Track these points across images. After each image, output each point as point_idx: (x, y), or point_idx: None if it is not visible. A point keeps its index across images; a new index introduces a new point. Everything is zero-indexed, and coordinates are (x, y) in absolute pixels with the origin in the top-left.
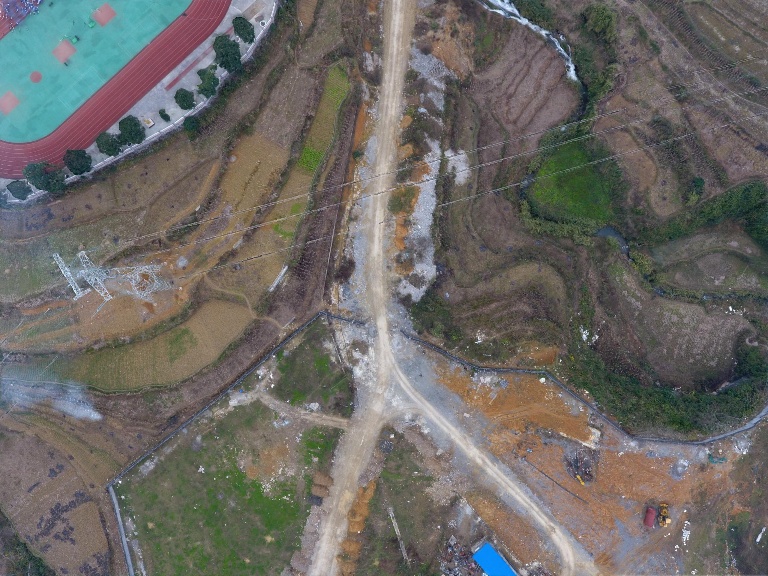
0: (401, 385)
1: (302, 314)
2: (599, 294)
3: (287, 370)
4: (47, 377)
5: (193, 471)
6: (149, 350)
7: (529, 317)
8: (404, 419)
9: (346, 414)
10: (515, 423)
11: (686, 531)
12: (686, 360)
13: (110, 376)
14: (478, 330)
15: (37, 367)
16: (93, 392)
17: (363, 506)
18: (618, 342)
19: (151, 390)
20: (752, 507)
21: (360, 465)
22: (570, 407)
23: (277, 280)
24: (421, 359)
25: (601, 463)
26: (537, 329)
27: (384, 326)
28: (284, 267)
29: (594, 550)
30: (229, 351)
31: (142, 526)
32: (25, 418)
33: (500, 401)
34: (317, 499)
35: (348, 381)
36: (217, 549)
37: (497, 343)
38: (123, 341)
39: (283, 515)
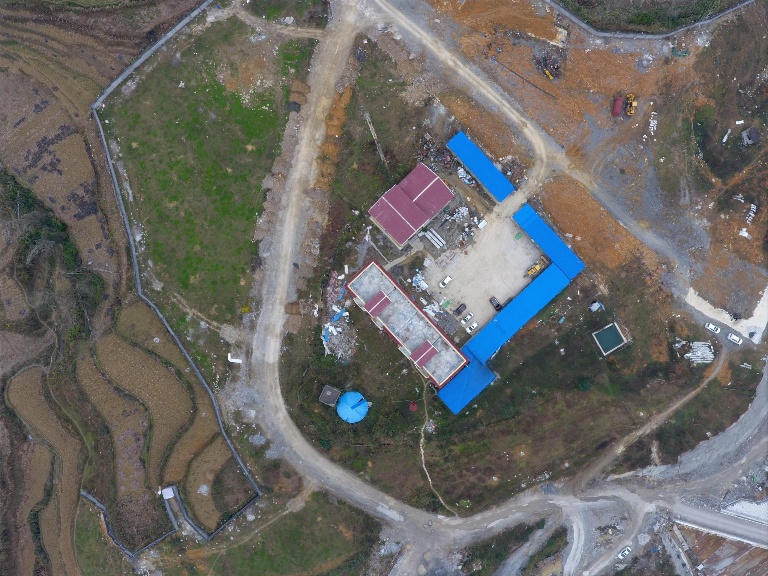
0: None
1: None
2: None
3: None
4: None
5: (174, 87)
6: None
7: None
8: (377, 28)
9: (320, 25)
10: (484, 26)
11: (653, 119)
12: (652, 8)
13: None
14: None
15: None
16: (73, 7)
17: (340, 109)
18: None
19: (130, 4)
20: (716, 102)
21: (336, 72)
22: (537, 8)
23: None
24: None
25: (569, 60)
26: None
27: None
28: None
29: (565, 142)
30: None
31: (126, 147)
32: (8, 48)
33: (469, 6)
34: (295, 104)
35: None
36: (200, 161)
37: None
38: None
39: (263, 124)
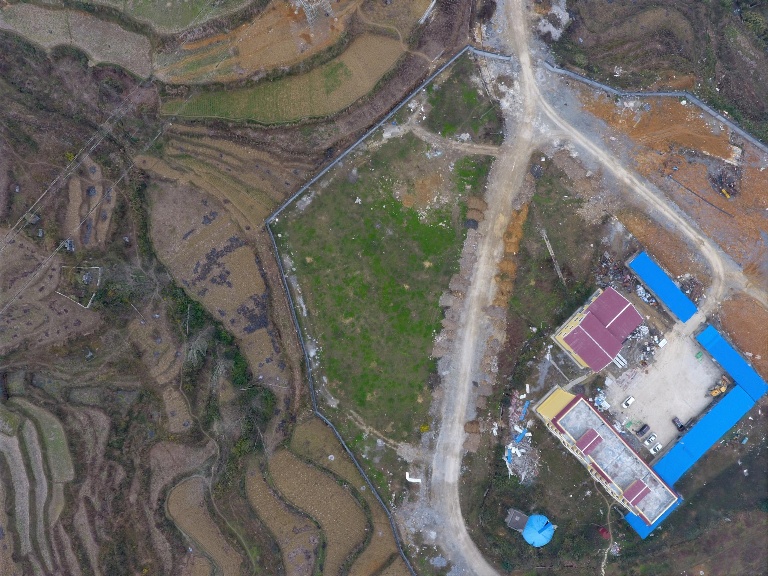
0: (547, 114)
1: (450, 48)
2: (717, 50)
3: (437, 103)
4: (207, 112)
5: (350, 203)
6: (305, 83)
7: (663, 52)
8: (553, 145)
9: (497, 142)
10: (660, 144)
11: None
12: None
13: (268, 109)
14: (615, 66)
15: (197, 102)
16: (252, 125)
17: (518, 227)
18: (738, 94)
19: (309, 122)
20: None
21: (513, 189)
22: (711, 127)
23: (427, 12)
24: (565, 90)
25: (744, 178)
26: (672, 62)
27: (527, 61)
28: (433, 0)
29: (742, 260)
30: (383, 82)
31: (300, 261)
32: (181, 162)
33: (644, 124)
34: (474, 222)
35: (496, 112)
36: (377, 277)
37: (636, 74)
38: (282, 71)
39: (440, 240)
